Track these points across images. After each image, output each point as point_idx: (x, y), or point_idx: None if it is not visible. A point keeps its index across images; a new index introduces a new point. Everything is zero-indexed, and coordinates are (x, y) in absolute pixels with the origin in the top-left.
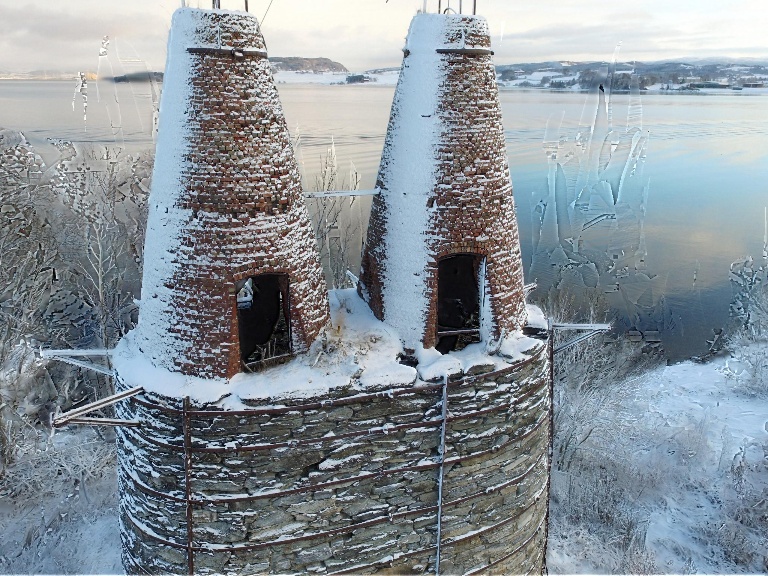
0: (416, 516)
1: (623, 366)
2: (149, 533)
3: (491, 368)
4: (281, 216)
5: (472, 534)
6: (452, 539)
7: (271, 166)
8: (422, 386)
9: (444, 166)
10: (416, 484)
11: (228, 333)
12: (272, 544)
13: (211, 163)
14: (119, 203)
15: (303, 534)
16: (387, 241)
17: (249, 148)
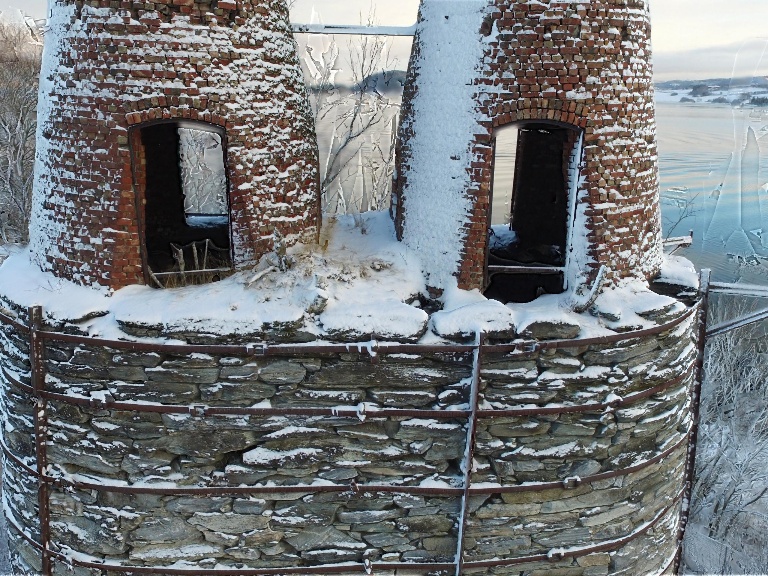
0: (415, 573)
1: None
2: (7, 515)
3: (572, 332)
4: (221, 29)
5: None
6: None
7: None
8: (434, 344)
9: None
10: (416, 518)
11: (114, 212)
12: (163, 571)
13: None
14: (211, 150)
15: (214, 565)
16: (416, 106)
17: None
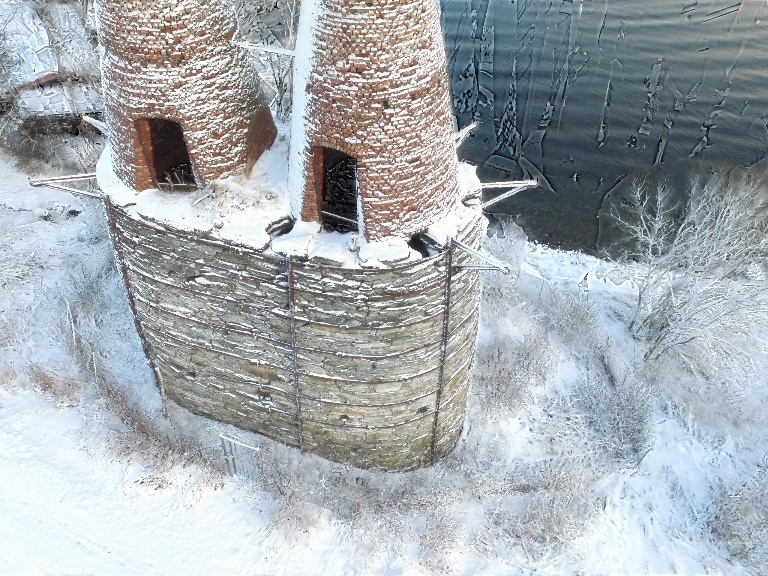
0: (277, 344)
1: (765, 291)
2: None
3: (337, 263)
4: (174, 69)
5: (325, 377)
6: (308, 372)
7: (161, 21)
8: (270, 255)
9: (318, 54)
10: (274, 323)
11: (134, 158)
12: (172, 314)
13: (109, 11)
14: None
15: (191, 317)
16: None
17: (137, 1)
